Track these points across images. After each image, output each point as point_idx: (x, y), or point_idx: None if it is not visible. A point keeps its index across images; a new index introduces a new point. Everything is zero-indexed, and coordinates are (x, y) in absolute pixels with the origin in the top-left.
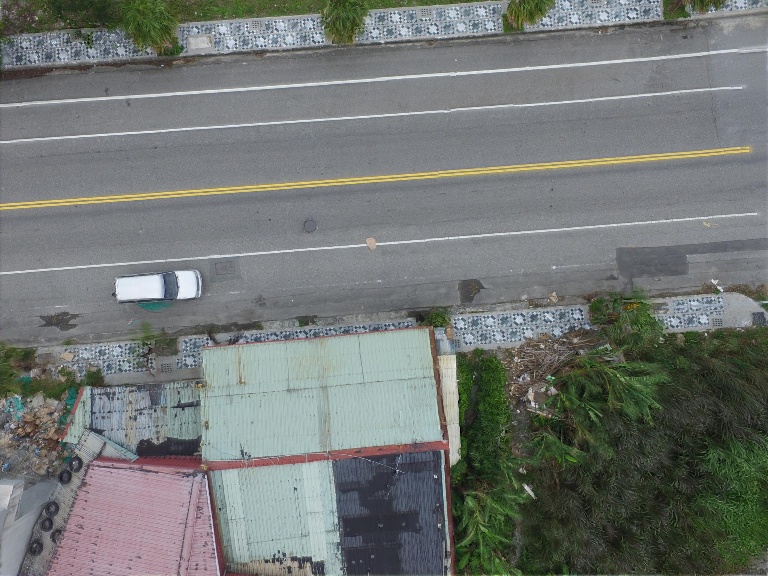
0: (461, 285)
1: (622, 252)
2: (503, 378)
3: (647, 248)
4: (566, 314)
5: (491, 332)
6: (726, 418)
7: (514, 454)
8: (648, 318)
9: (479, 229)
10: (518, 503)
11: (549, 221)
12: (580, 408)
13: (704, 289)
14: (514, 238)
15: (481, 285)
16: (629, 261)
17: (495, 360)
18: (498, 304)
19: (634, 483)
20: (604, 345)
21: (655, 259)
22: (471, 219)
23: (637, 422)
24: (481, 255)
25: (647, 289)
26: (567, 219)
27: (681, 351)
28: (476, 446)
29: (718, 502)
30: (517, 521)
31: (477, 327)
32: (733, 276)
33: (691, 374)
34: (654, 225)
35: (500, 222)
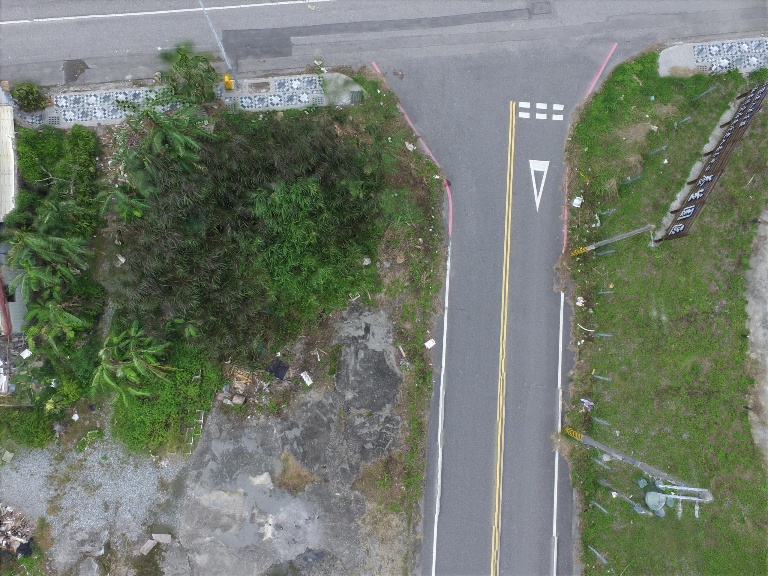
0: (66, 65)
1: (228, 34)
2: (81, 142)
3: (252, 30)
4: (169, 93)
5: (92, 110)
6: (278, 167)
7: (110, 226)
8: (186, 61)
9: (84, 10)
10: (112, 273)
11: (155, 4)
12: (136, 158)
13: (308, 70)
14: (120, 20)
15: (86, 65)
16: (235, 43)
17: (87, 132)
18: (102, 84)
19: (193, 233)
20: (201, 120)
21: (260, 41)
22: (76, 0)
23: (192, 172)
24: (85, 35)
25: (252, 70)
26: (174, 2)
27: (275, 125)
28: (42, 202)
29: (258, 242)
30: (111, 290)
31: (79, 105)
32: (336, 58)
33: (265, 136)
34: (259, 8)
35: (106, 4)
